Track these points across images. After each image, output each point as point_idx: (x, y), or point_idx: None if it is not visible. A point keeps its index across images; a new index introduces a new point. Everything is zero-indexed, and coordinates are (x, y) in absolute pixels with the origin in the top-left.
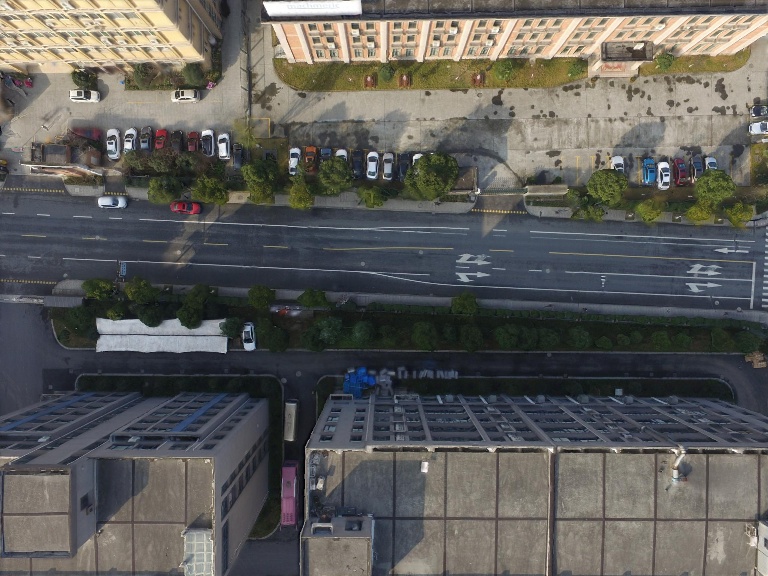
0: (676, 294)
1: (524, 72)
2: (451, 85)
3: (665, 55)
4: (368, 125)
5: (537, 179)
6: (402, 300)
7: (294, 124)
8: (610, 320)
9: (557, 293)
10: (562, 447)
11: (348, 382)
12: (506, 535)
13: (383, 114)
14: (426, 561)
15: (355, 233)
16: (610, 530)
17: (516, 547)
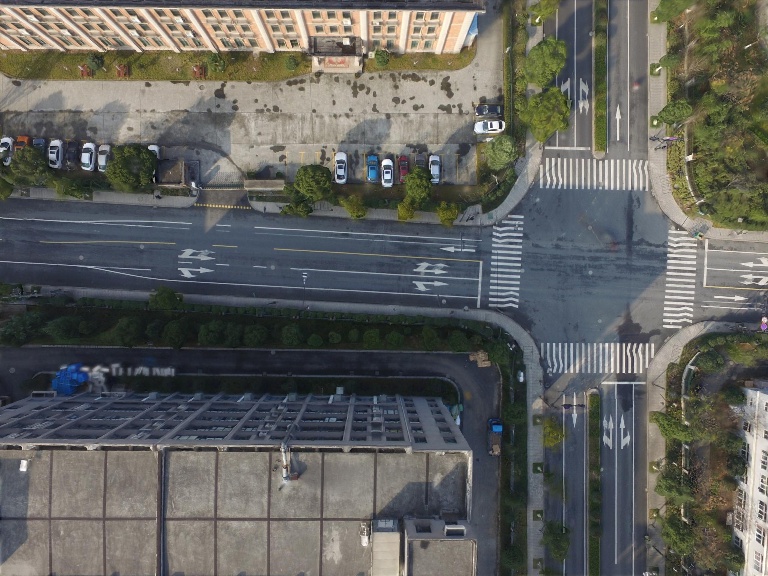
0: (403, 292)
1: (247, 65)
2: (172, 77)
3: (378, 51)
4: (86, 115)
5: (261, 174)
6: (122, 295)
7: (8, 113)
8: (328, 318)
9: (282, 290)
10: (162, 445)
11: (57, 379)
12: (114, 536)
13: (101, 105)
14: (31, 563)
15: (73, 226)
16: (222, 530)
17: (125, 548)
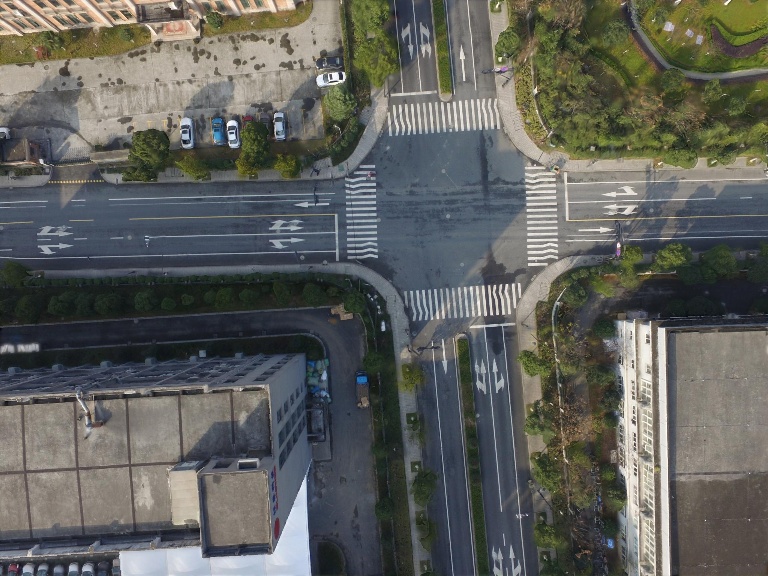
0: (261, 252)
1: (88, 42)
2: (17, 60)
3: (208, 13)
4: None
5: (110, 147)
6: None
7: None
8: (184, 281)
9: (141, 259)
10: None
11: None
12: None
13: None
14: None
15: None
16: (33, 482)
17: None
